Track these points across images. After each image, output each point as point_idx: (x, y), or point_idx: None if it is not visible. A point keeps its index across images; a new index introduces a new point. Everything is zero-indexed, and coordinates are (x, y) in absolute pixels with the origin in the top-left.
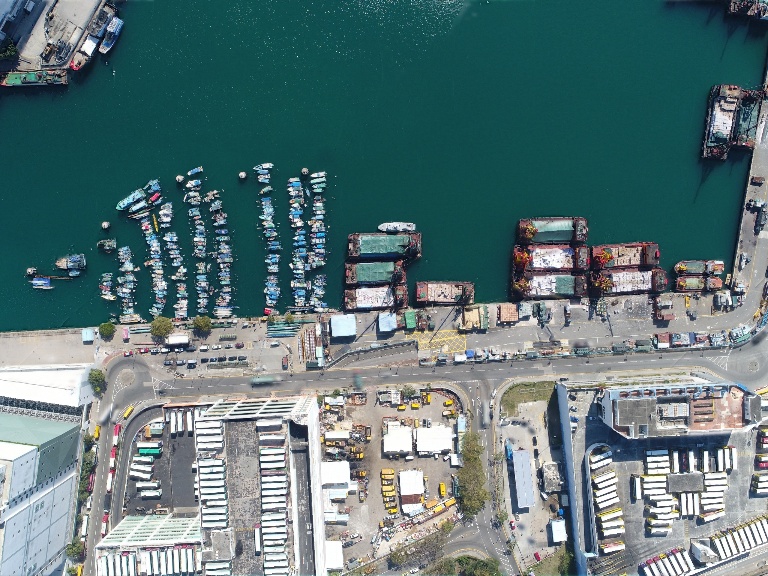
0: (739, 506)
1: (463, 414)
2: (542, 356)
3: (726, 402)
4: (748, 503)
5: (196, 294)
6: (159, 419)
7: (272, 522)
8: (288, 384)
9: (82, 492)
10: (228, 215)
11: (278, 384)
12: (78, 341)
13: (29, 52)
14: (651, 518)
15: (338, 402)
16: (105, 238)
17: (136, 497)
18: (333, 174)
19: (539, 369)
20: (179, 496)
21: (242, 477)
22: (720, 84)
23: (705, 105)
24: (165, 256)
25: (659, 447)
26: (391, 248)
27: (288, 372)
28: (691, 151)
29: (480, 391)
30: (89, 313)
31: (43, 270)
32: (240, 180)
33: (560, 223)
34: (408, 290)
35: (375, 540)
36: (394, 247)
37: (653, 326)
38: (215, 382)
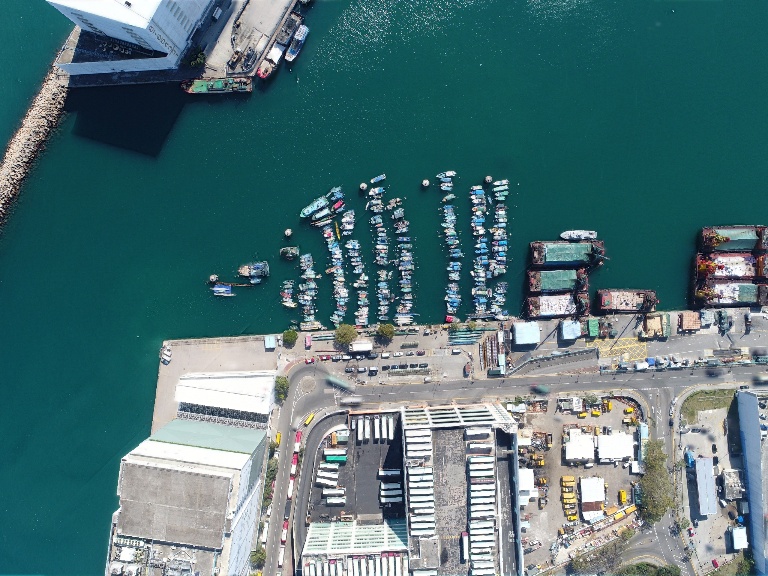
0: None
1: (644, 422)
2: (723, 364)
3: None
4: None
5: (377, 301)
6: (340, 426)
7: (481, 530)
8: (469, 391)
9: (265, 499)
10: (410, 223)
11: (459, 391)
12: (259, 348)
13: (215, 60)
14: None
15: (520, 409)
16: (287, 245)
17: (320, 504)
18: (515, 182)
19: (719, 377)
20: (363, 503)
21: (448, 485)
22: None
23: None
24: (346, 263)
25: None
26: (577, 256)
27: (469, 379)
28: None
29: (660, 399)
30: (270, 320)
31: (224, 277)
32: (422, 188)
33: (744, 231)
34: (589, 298)
35: (554, 547)
36: (580, 255)
37: None
38: (396, 389)
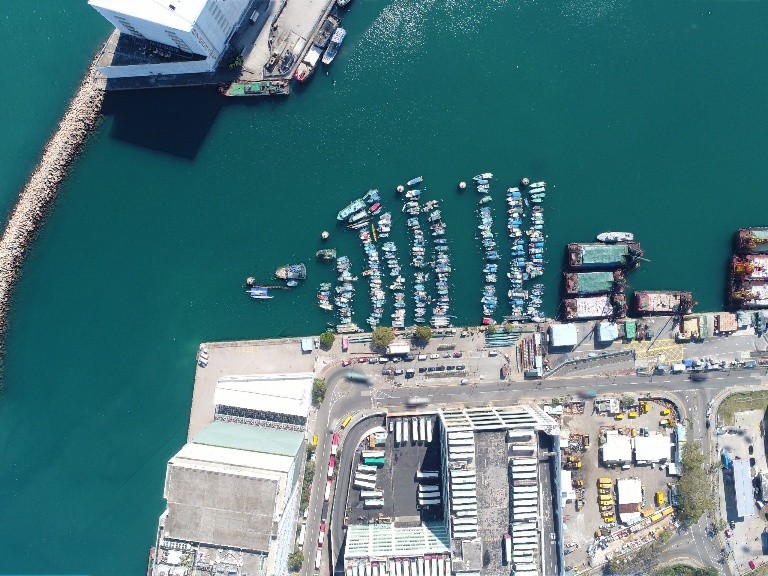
0: None
1: (680, 423)
2: (760, 365)
3: None
4: None
5: (413, 304)
6: (377, 428)
7: (523, 532)
8: (506, 393)
9: (302, 501)
10: (446, 225)
11: (496, 393)
12: (296, 350)
13: (252, 62)
14: None
15: (557, 411)
16: (323, 248)
17: (358, 506)
18: (552, 184)
19: (756, 378)
20: (401, 505)
21: (490, 487)
22: None
23: None
24: (383, 266)
25: None
26: (614, 258)
27: (506, 381)
28: None
29: (697, 400)
30: (306, 323)
31: (261, 280)
32: (459, 190)
33: None
34: (626, 300)
35: (591, 549)
36: (617, 257)
37: None
38: (433, 391)
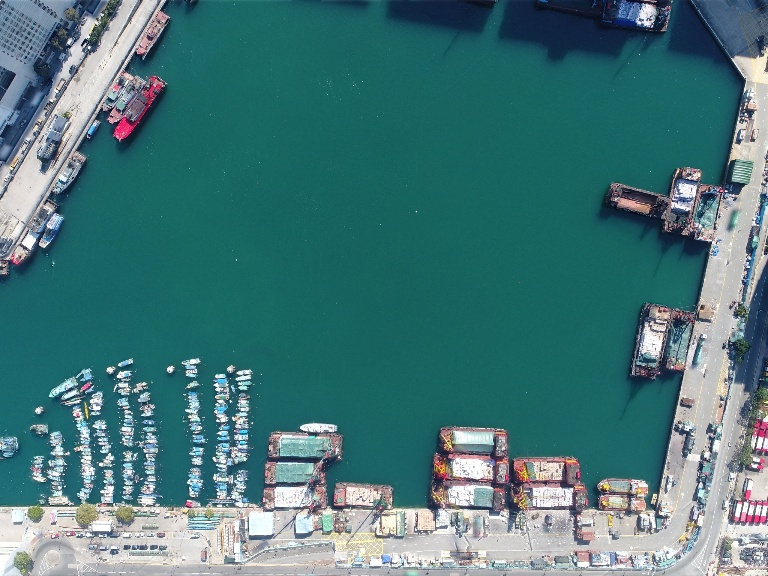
0: None
1: None
2: (458, 566)
3: None
4: None
5: (122, 481)
6: None
7: None
8: (206, 575)
9: None
10: (156, 406)
11: (197, 575)
12: (9, 520)
13: None
14: None
15: None
16: (38, 422)
17: None
18: (258, 372)
19: None
20: None
21: None
22: (653, 300)
23: (636, 321)
24: (94, 442)
25: None
26: (310, 453)
27: (207, 564)
28: (620, 367)
29: None
30: (21, 493)
31: None
32: (168, 373)
33: (481, 436)
34: (327, 491)
35: None
36: (313, 452)
37: (574, 543)
38: (136, 569)
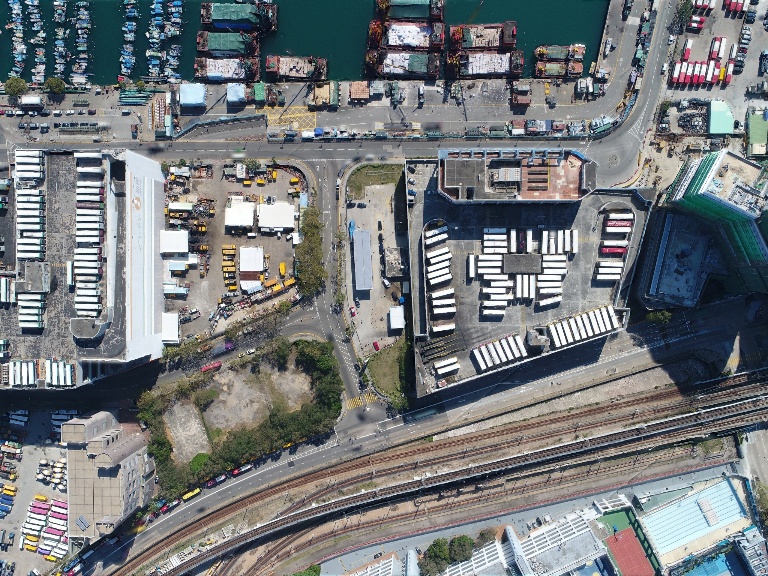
0: (580, 295)
1: (308, 193)
2: (392, 137)
3: (562, 171)
4: (590, 292)
5: (54, 60)
6: None
7: (84, 256)
8: None
9: None
10: None
11: None
12: None
13: None
14: (485, 300)
15: (183, 172)
16: None
17: None
18: None
19: (388, 151)
20: None
21: (61, 212)
22: None
23: None
24: (26, 20)
25: (499, 227)
26: (242, 14)
27: (137, 141)
28: None
29: (327, 171)
30: None
31: None
32: None
33: None
34: (261, 64)
35: (213, 317)
36: (245, 14)
37: (510, 112)
38: (66, 148)
